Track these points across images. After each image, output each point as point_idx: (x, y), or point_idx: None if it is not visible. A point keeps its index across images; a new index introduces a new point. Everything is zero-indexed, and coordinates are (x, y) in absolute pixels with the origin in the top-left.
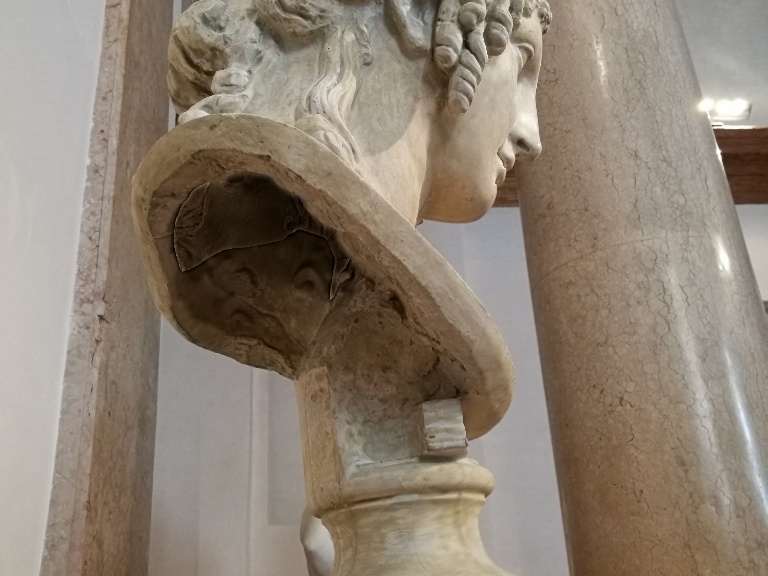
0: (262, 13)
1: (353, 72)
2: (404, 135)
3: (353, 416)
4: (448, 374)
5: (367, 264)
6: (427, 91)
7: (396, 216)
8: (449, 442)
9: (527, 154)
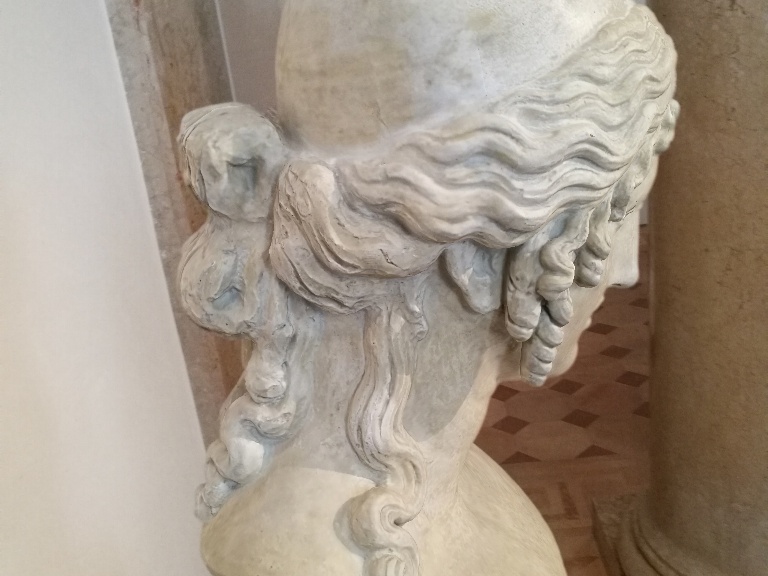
0: None
1: (406, 373)
2: (469, 393)
3: None
4: None
5: None
6: (496, 339)
7: None
8: None
9: (618, 287)
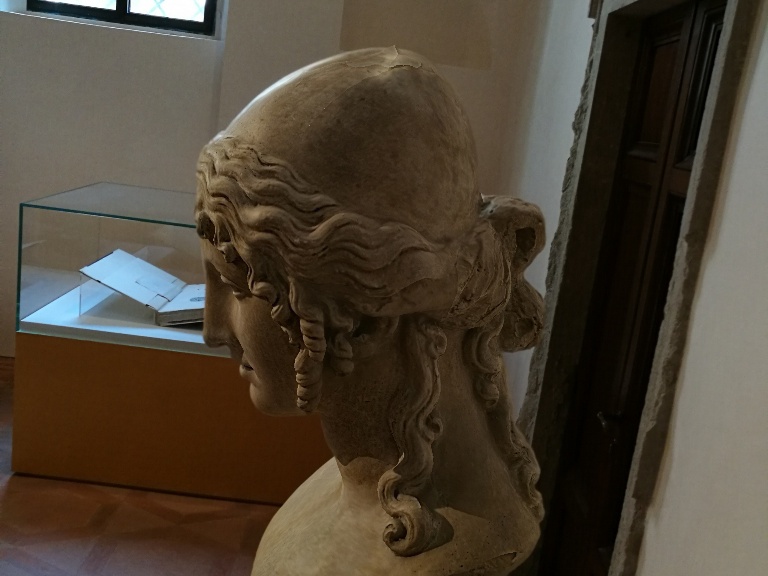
0: None
1: None
2: None
3: None
4: None
5: None
6: None
7: None
8: None
9: None
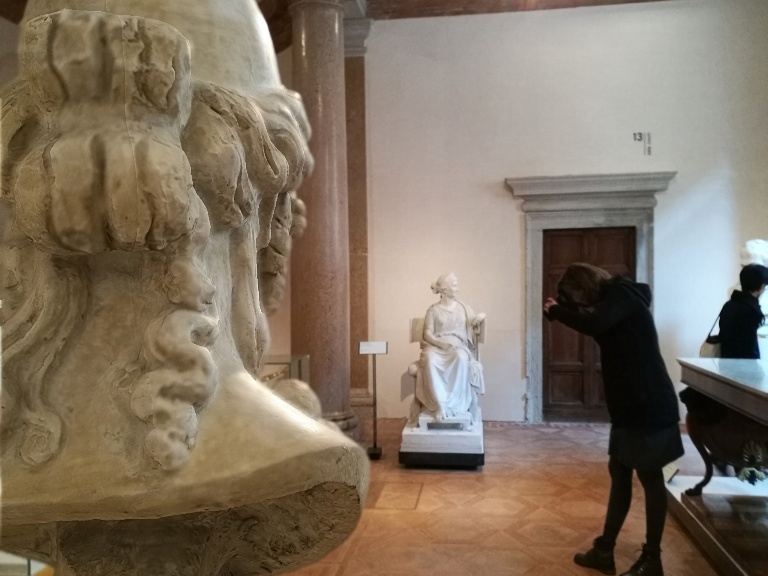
0: (211, 186)
1: None
2: None
3: None
4: (232, 564)
5: None
6: None
7: None
8: None
9: None
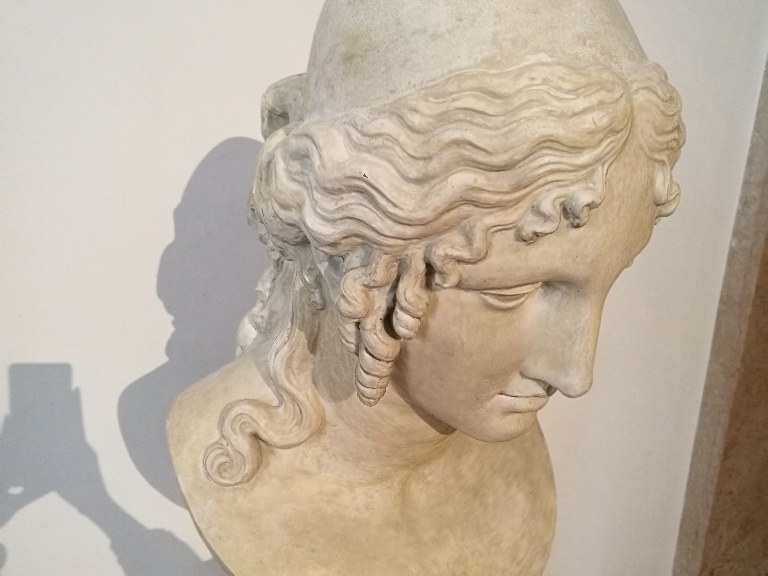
0: None
1: (299, 328)
2: None
3: None
4: None
5: None
6: None
7: (219, 559)
8: None
9: None
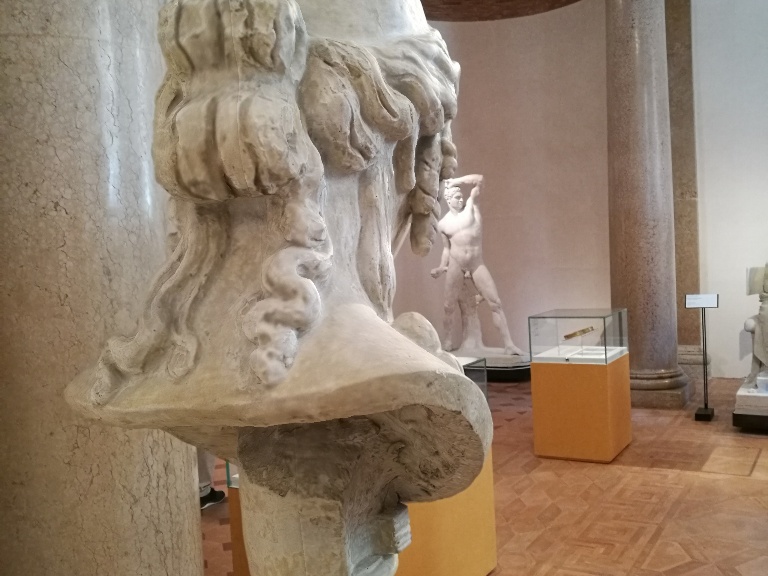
0: (325, 134)
1: None
2: None
3: (348, 535)
4: (396, 485)
5: (381, 415)
6: (397, 222)
7: None
8: (406, 544)
9: None
